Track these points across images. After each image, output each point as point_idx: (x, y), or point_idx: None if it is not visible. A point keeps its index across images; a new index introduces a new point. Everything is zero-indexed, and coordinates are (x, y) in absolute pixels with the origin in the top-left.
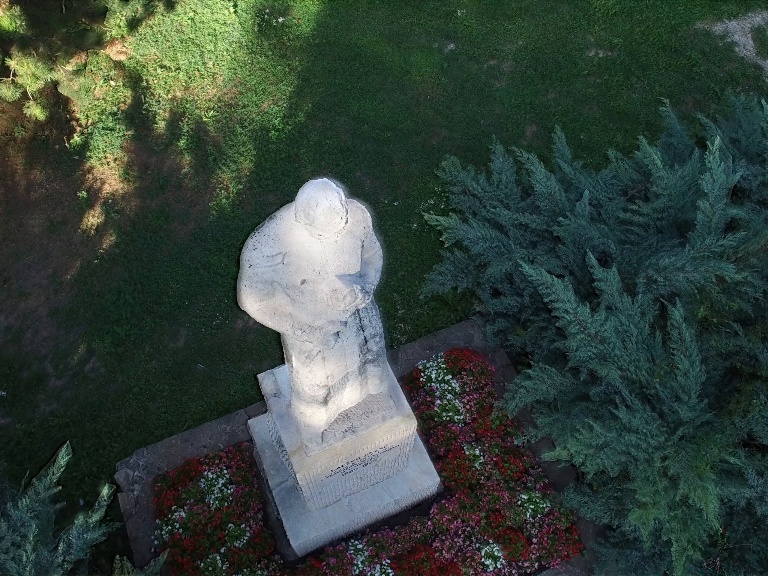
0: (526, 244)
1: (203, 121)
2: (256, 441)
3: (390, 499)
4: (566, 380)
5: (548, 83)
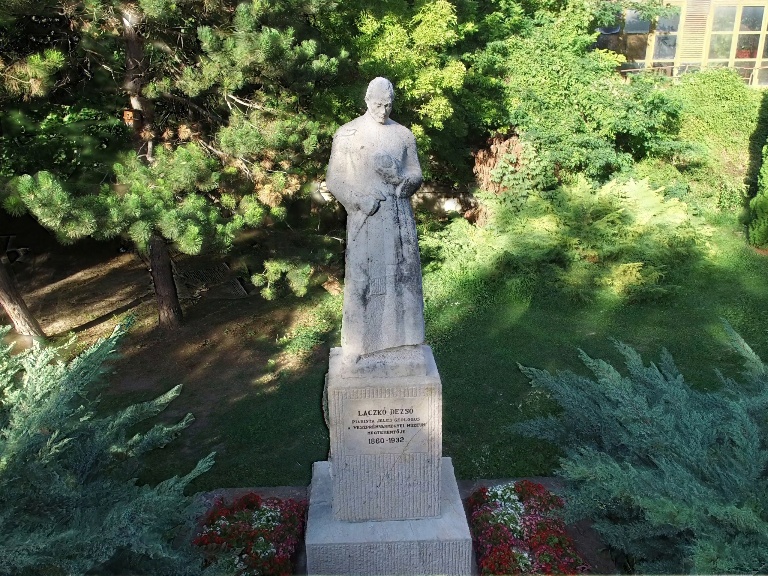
0: None
1: None
2: (314, 474)
3: (414, 535)
4: None
5: (679, 359)
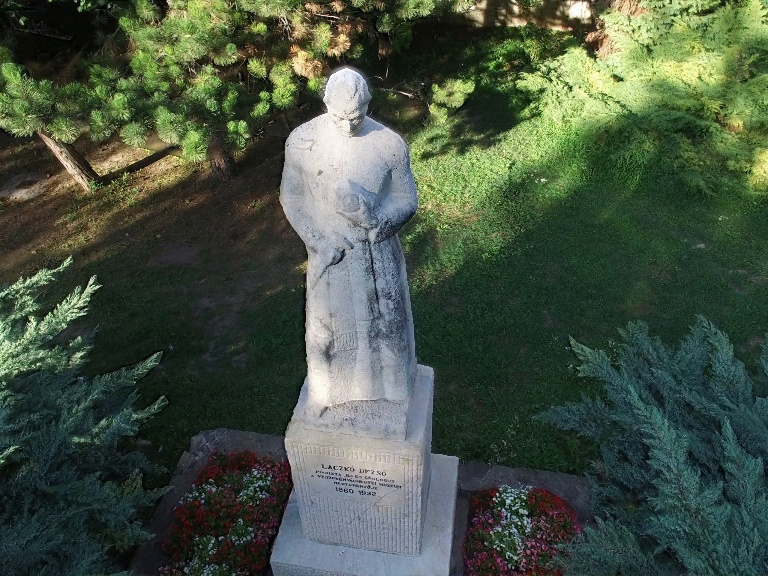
0: (682, 424)
1: (436, 230)
2: None
3: (384, 575)
4: (643, 556)
5: None
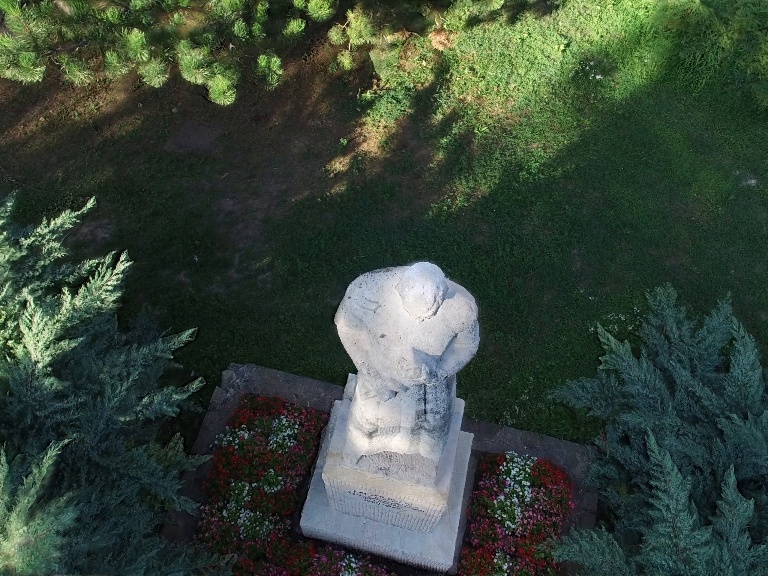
0: (687, 415)
1: (474, 132)
2: (331, 421)
3: (399, 548)
4: (627, 569)
5: None
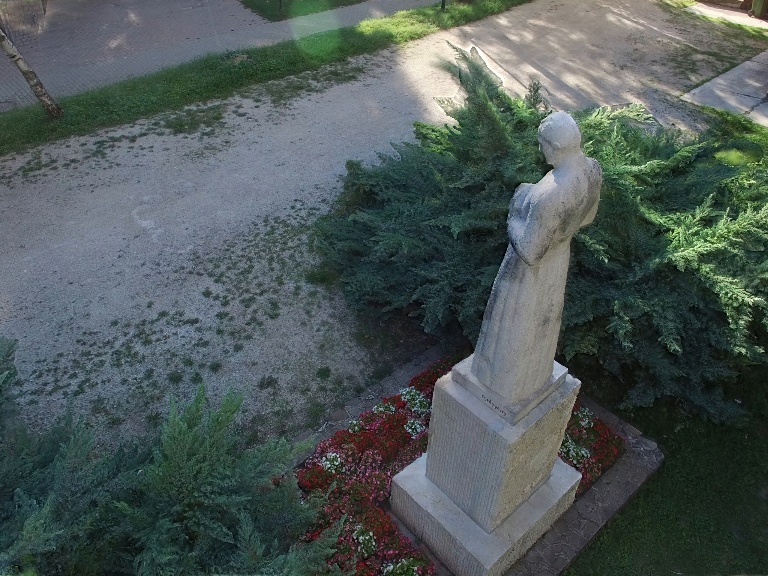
0: None
1: None
2: None
3: None
4: None
5: None
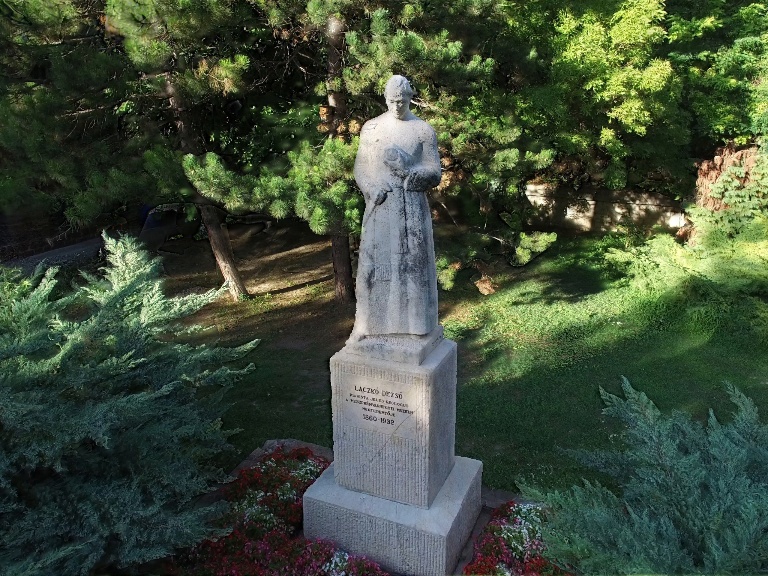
0: None
1: (513, 349)
2: None
3: None
4: None
5: None
